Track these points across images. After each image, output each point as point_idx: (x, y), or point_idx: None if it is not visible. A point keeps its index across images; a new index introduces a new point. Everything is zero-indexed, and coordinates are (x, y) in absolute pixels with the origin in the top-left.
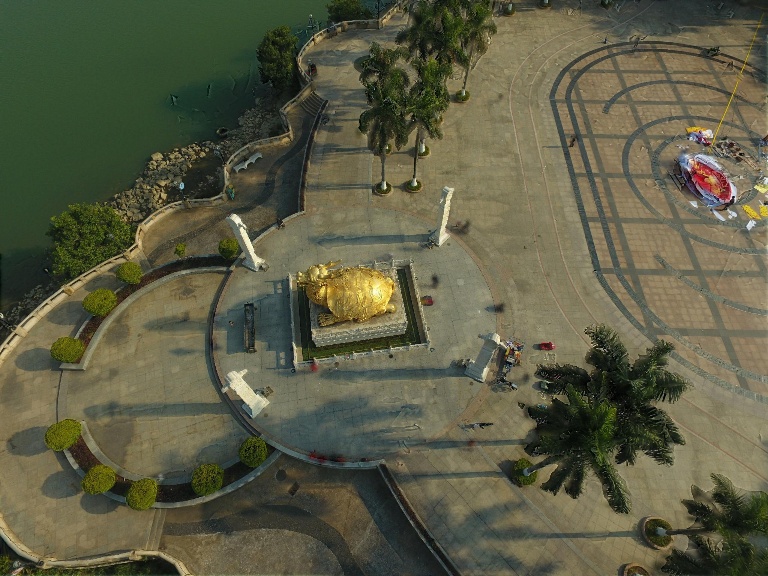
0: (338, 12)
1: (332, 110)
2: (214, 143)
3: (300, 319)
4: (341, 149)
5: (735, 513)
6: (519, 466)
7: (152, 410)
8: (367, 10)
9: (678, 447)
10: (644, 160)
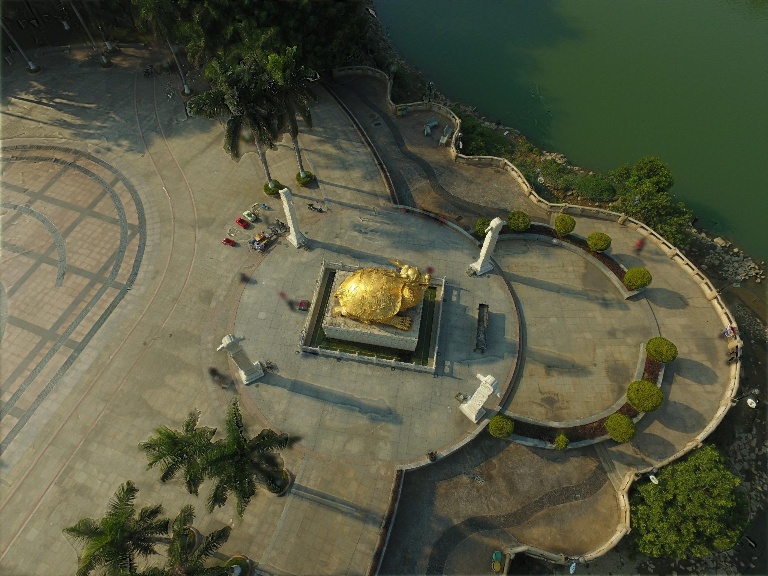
0: None
1: None
2: None
3: None
4: None
5: None
6: (306, 179)
7: (569, 292)
8: None
9: (197, 166)
10: None
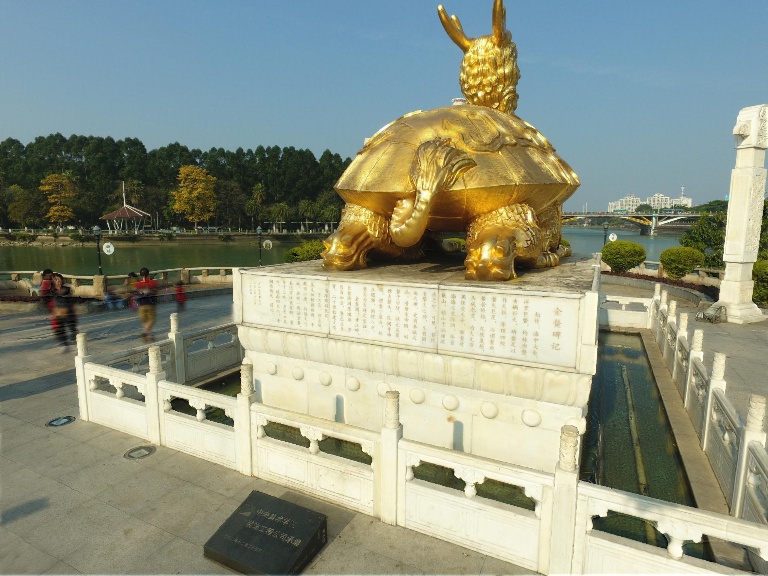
0: None
1: None
2: None
3: None
4: None
5: None
6: None
7: None
8: None
9: None
10: None
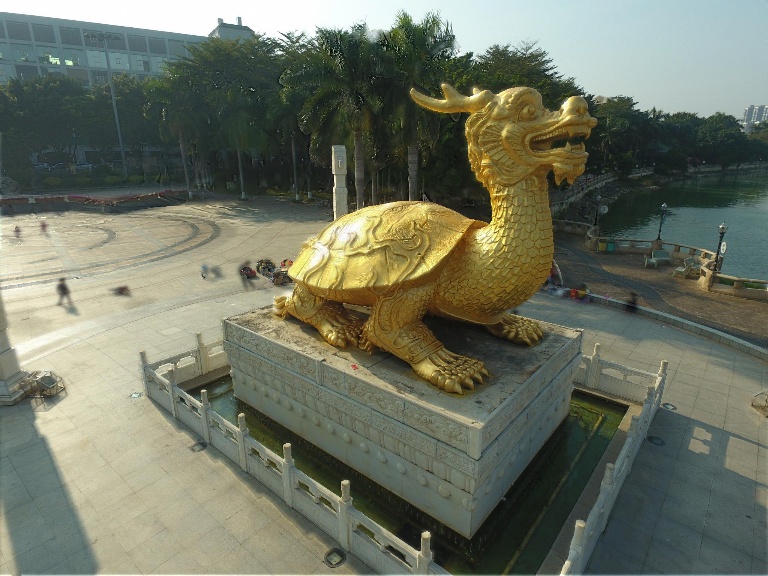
0: None
1: None
2: None
3: None
4: None
5: None
6: None
7: None
8: None
9: (297, 237)
10: None
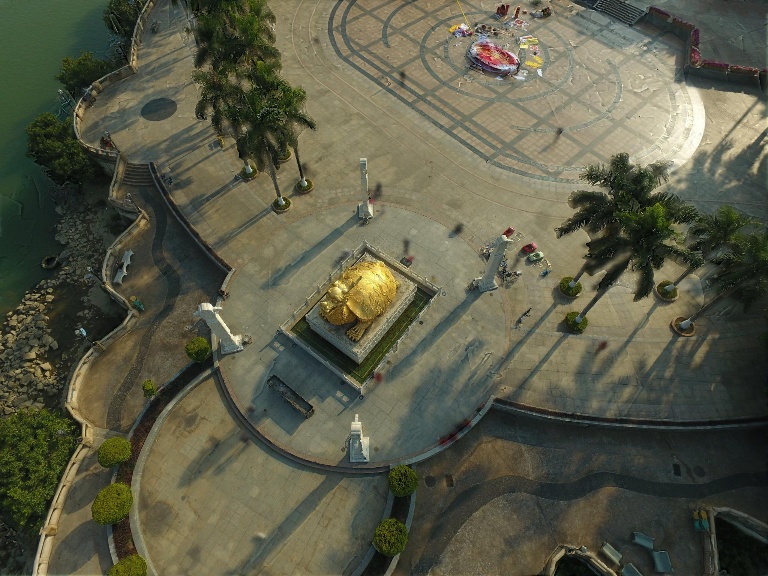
0: (79, 76)
1: (164, 168)
2: (51, 279)
3: (322, 356)
4: (210, 196)
5: (722, 229)
6: (571, 320)
7: (271, 543)
8: (105, 62)
9: None
10: (444, 67)
